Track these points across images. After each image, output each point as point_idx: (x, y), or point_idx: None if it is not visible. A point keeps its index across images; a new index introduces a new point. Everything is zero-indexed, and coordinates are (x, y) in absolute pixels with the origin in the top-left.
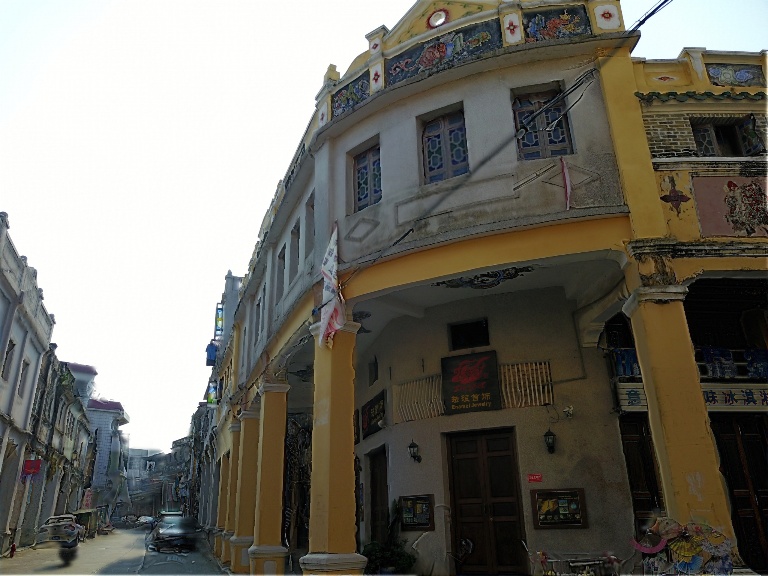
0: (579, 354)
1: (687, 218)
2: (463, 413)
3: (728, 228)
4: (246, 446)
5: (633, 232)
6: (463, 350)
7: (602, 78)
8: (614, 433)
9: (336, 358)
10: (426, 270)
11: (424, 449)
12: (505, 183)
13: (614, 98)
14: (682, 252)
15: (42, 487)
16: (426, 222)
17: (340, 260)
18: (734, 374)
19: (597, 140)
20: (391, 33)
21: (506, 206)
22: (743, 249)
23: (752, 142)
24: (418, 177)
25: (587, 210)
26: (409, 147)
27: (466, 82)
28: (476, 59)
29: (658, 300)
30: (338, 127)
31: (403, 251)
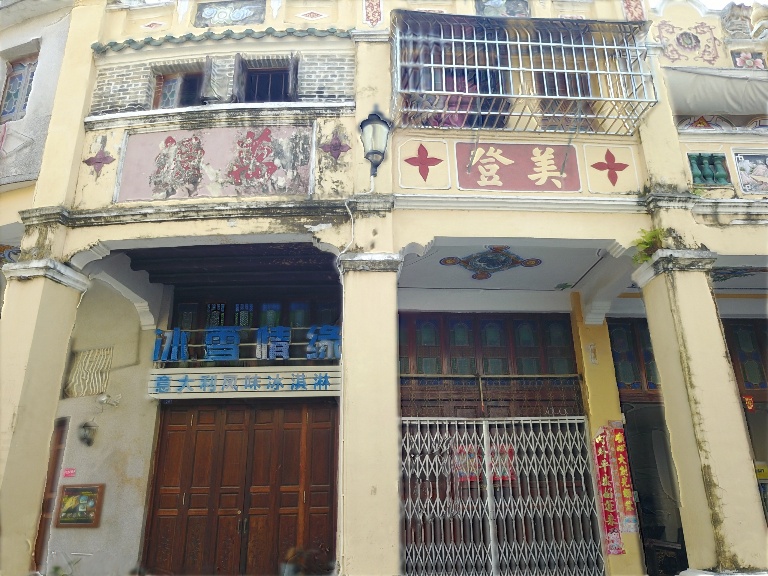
0: (137, 338)
1: (104, 182)
2: None
3: (147, 191)
4: None
5: (32, 202)
6: None
7: None
8: (149, 423)
9: None
10: None
11: None
12: None
13: (70, 52)
14: (81, 221)
15: None
16: None
17: None
18: (286, 355)
19: (45, 101)
20: None
21: None
22: (144, 214)
23: None
24: None
25: None
26: None
27: None
28: None
29: (20, 277)
30: None
31: None
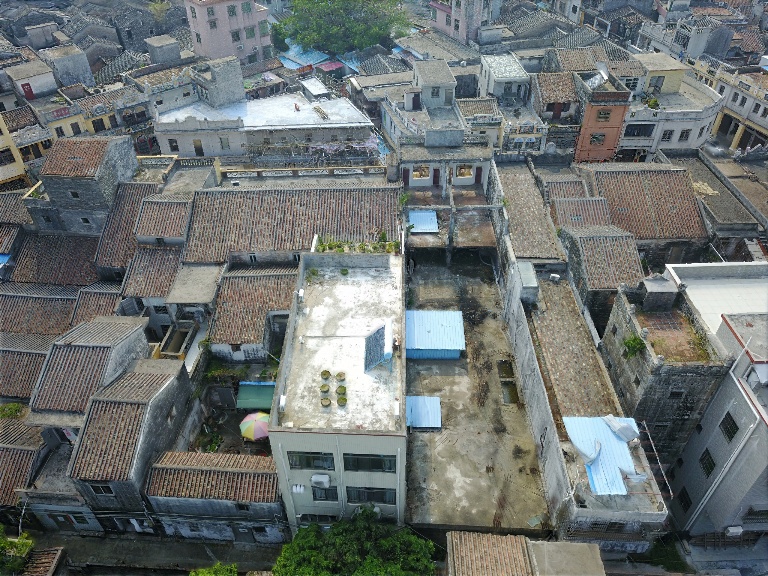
0: None
1: None
2: None
3: None
4: (720, 119)
5: None
6: None
7: None
8: None
9: None
10: None
11: None
12: None
13: None
14: None
15: None
16: None
17: None
18: None
19: None
20: None
21: None
22: None
23: None
24: None
25: None
26: None
27: None
28: None
29: None
30: None
31: None
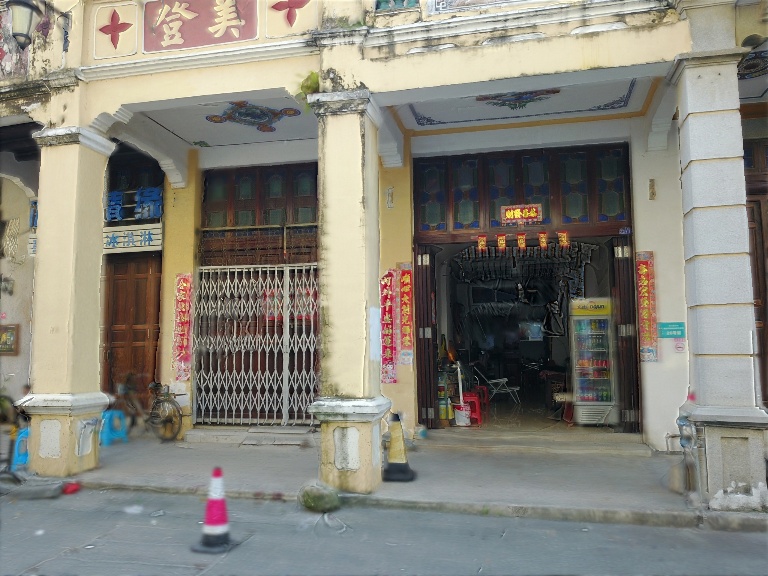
0: (29, 208)
1: None
2: None
3: None
4: None
5: None
6: None
7: None
8: None
9: None
10: None
11: None
12: None
13: None
14: None
15: None
16: None
17: None
18: (118, 217)
19: None
20: None
21: None
22: None
23: None
24: None
25: None
26: None
27: None
28: None
29: None
30: None
31: None
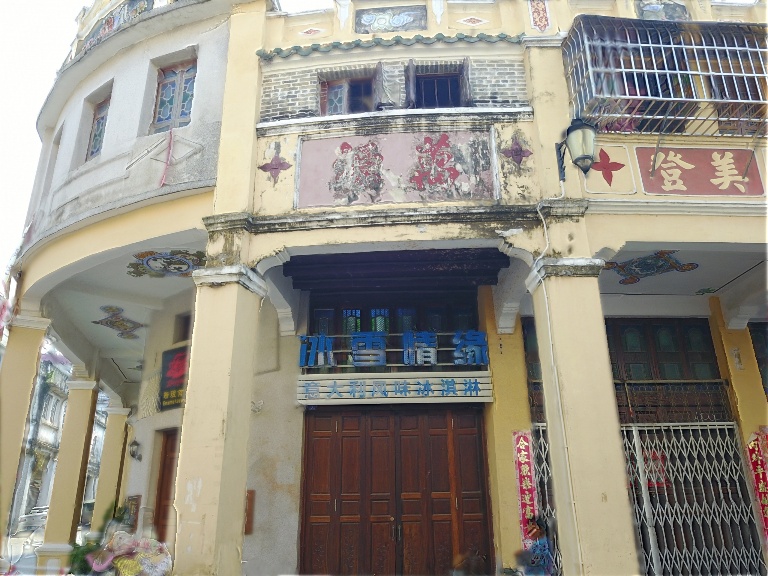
0: (276, 344)
1: (283, 188)
2: (170, 410)
3: (328, 197)
4: (107, 442)
5: (213, 208)
6: (180, 343)
7: (229, 38)
8: (296, 430)
9: (10, 356)
10: (55, 261)
11: (144, 448)
12: (121, 163)
13: (234, 59)
14: (264, 227)
15: (26, 479)
16: (62, 210)
17: (20, 254)
18: (434, 361)
19: (211, 108)
20: (87, 12)
21: (116, 188)
22: (331, 220)
23: (376, 95)
24: (70, 163)
25: (173, 186)
26: (73, 131)
27: (121, 57)
28: (116, 31)
29: (212, 283)
30: (47, 116)
31: (37, 242)
